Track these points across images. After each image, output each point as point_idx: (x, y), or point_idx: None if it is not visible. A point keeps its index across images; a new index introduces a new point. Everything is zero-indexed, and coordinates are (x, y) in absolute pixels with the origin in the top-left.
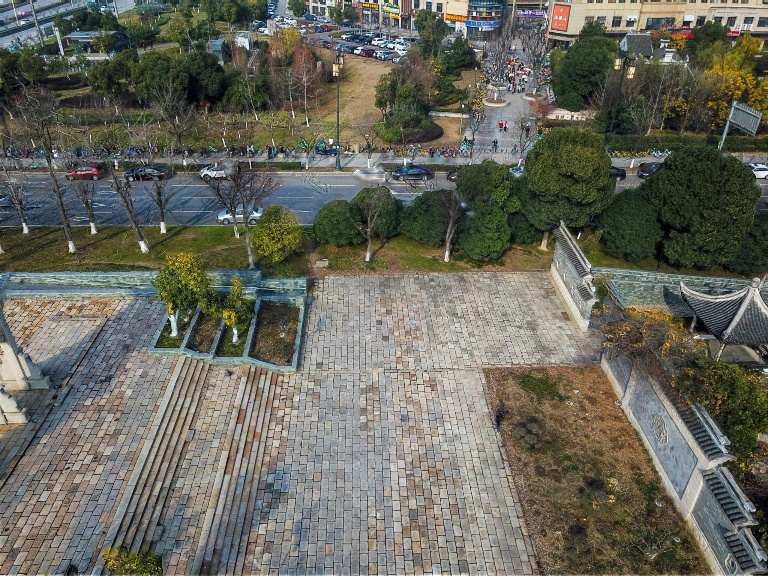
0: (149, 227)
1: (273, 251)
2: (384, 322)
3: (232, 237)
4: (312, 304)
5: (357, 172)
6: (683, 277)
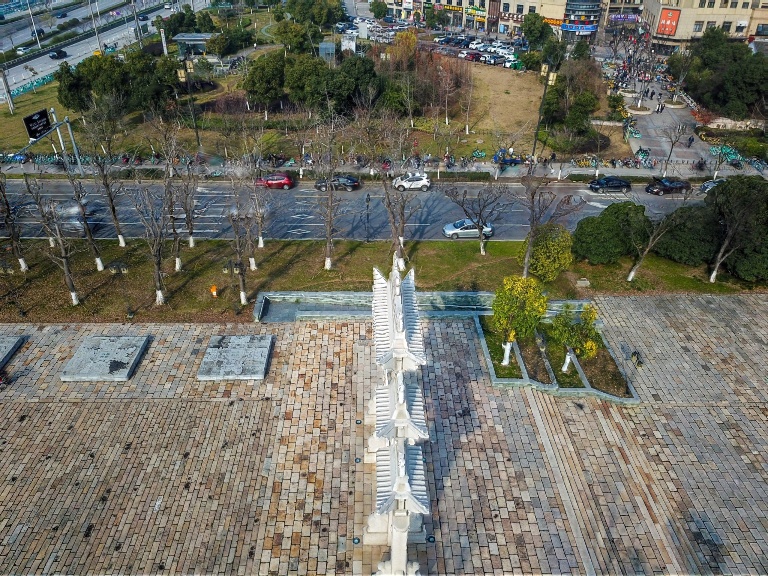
0: (378, 241)
1: (549, 271)
2: (691, 349)
3: (477, 253)
4: (602, 328)
5: (554, 183)
6: None
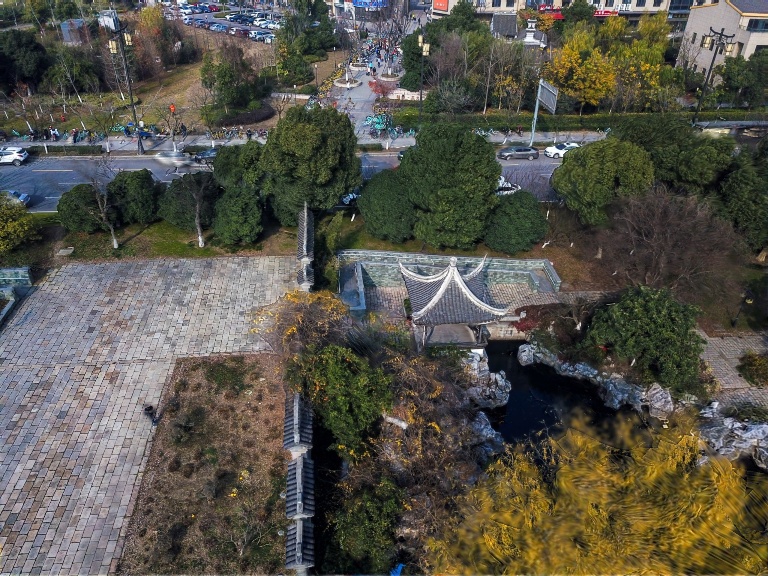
0: None
1: None
2: (99, 312)
3: None
4: (31, 295)
5: (157, 155)
6: (444, 258)
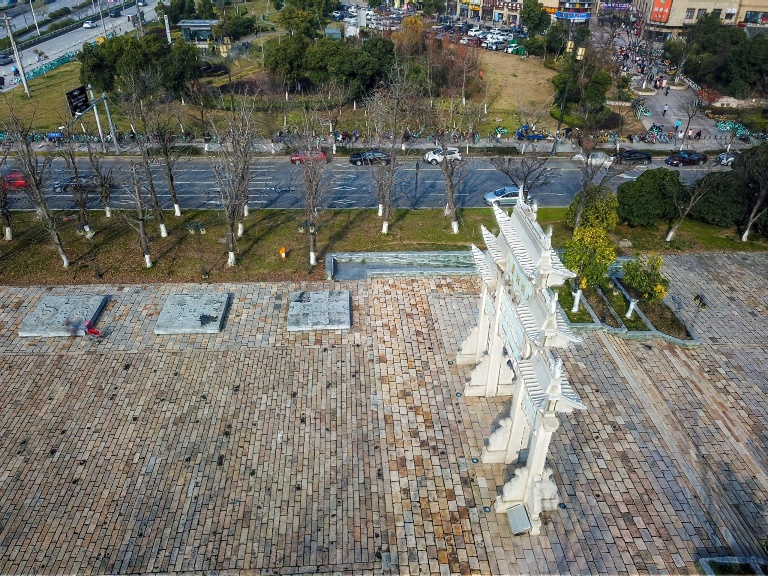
0: (424, 209)
1: None
2: (737, 298)
3: None
4: None
5: (579, 157)
6: None
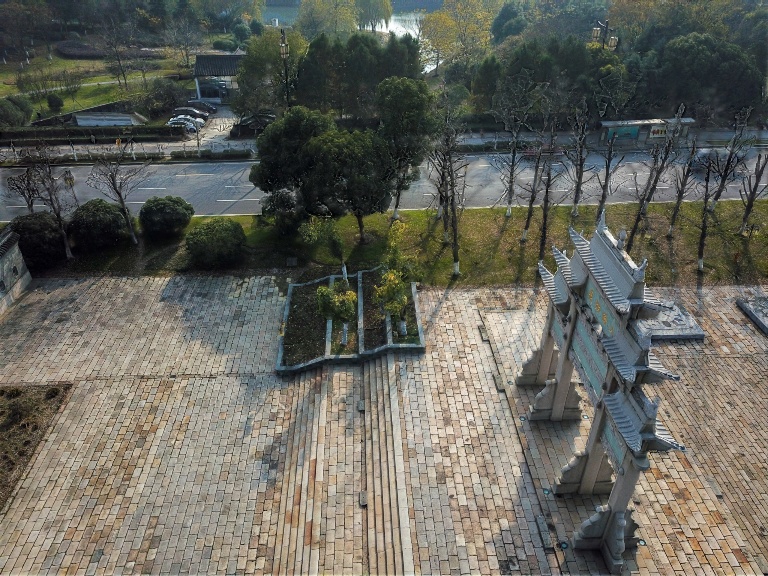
0: None
1: None
2: None
3: None
4: None
5: None
6: None
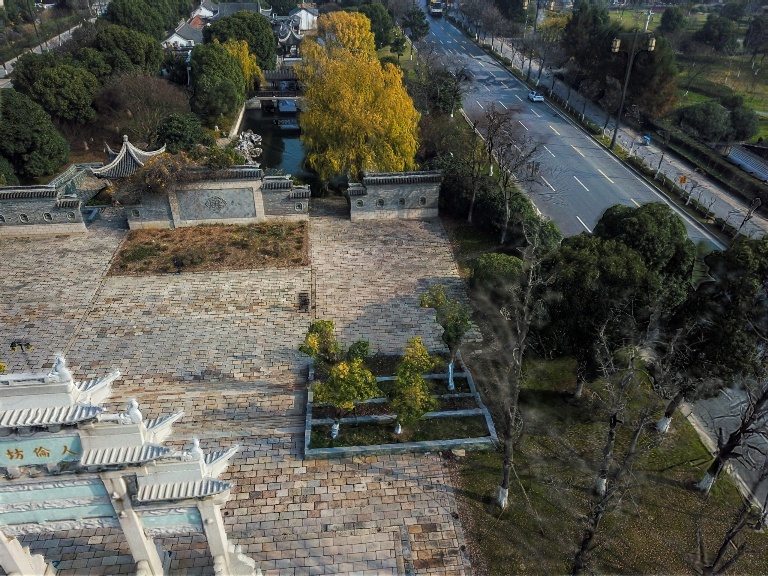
0: None
1: None
2: None
3: None
4: None
5: None
6: None
